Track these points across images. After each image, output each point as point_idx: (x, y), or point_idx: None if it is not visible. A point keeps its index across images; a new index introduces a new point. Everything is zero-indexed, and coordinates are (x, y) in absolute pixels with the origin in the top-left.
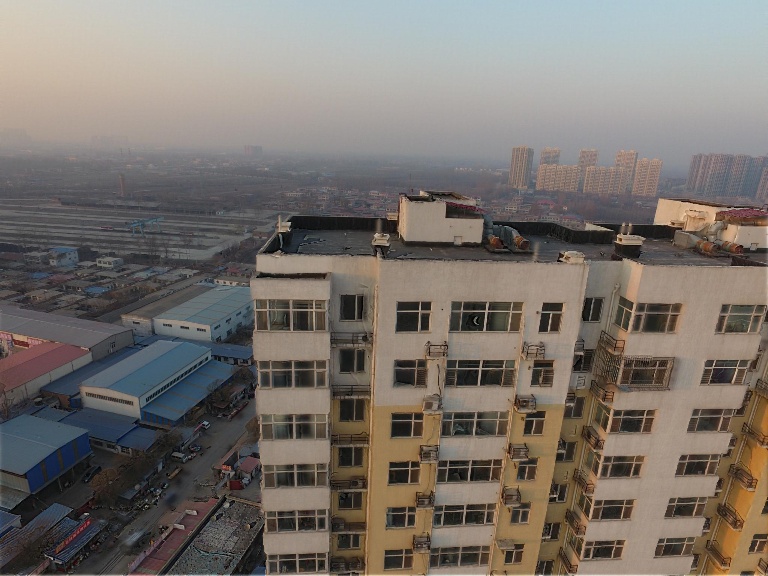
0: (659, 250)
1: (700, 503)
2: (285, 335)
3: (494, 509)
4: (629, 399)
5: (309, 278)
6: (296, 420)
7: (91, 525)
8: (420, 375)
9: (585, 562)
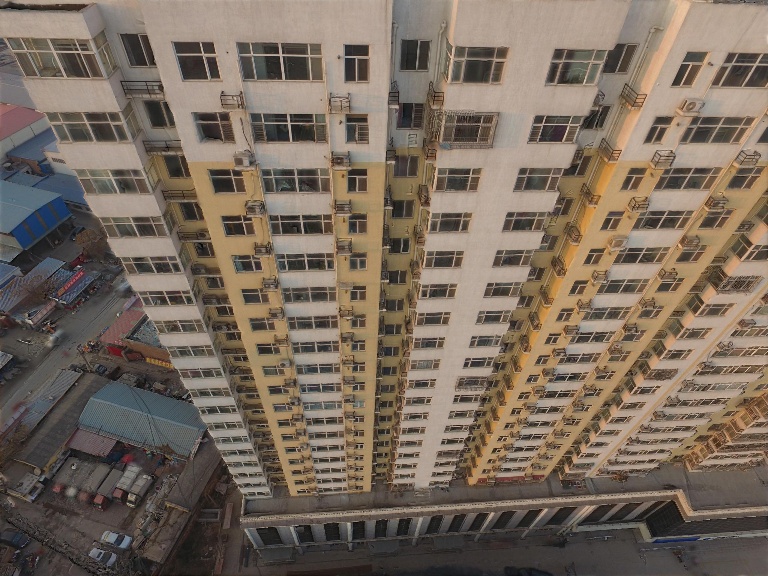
0: None
1: (526, 255)
2: (59, 82)
3: (333, 258)
4: (452, 157)
5: (58, 10)
6: (113, 175)
7: (85, 275)
8: (225, 130)
9: (422, 300)
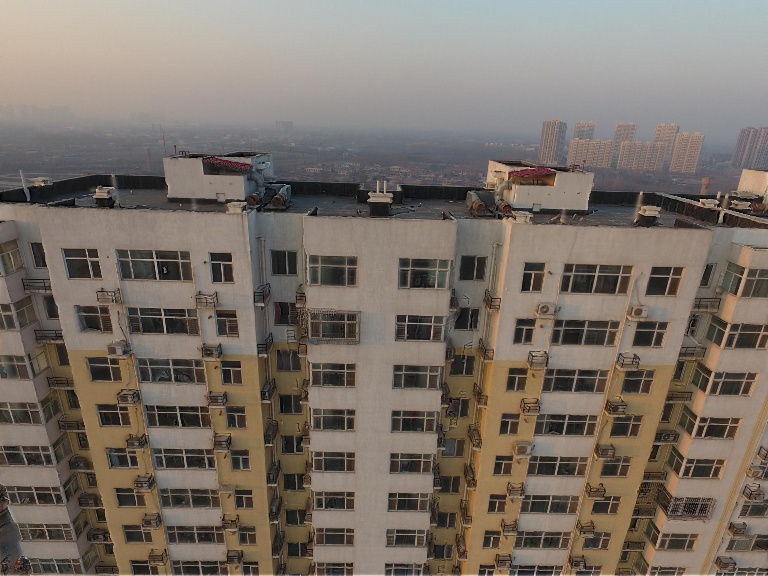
0: (436, 210)
1: (425, 460)
2: None
3: (213, 455)
4: (323, 352)
5: None
6: None
7: None
8: (104, 321)
9: (317, 511)
